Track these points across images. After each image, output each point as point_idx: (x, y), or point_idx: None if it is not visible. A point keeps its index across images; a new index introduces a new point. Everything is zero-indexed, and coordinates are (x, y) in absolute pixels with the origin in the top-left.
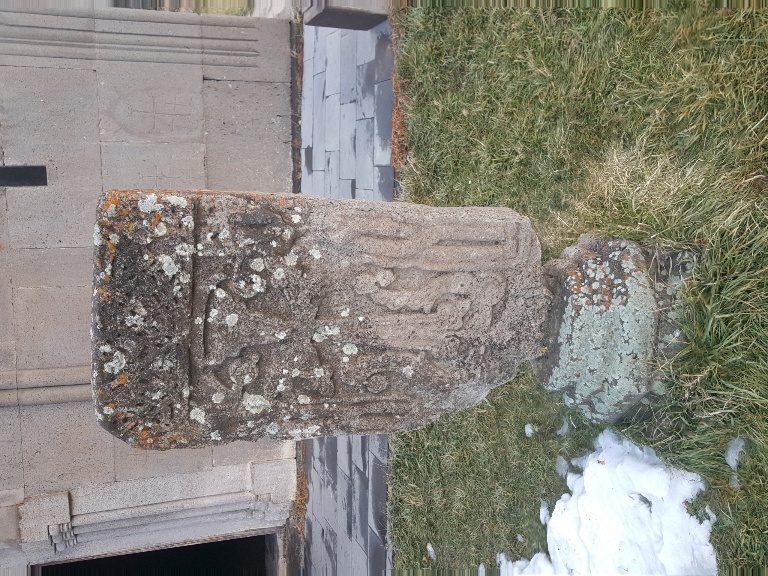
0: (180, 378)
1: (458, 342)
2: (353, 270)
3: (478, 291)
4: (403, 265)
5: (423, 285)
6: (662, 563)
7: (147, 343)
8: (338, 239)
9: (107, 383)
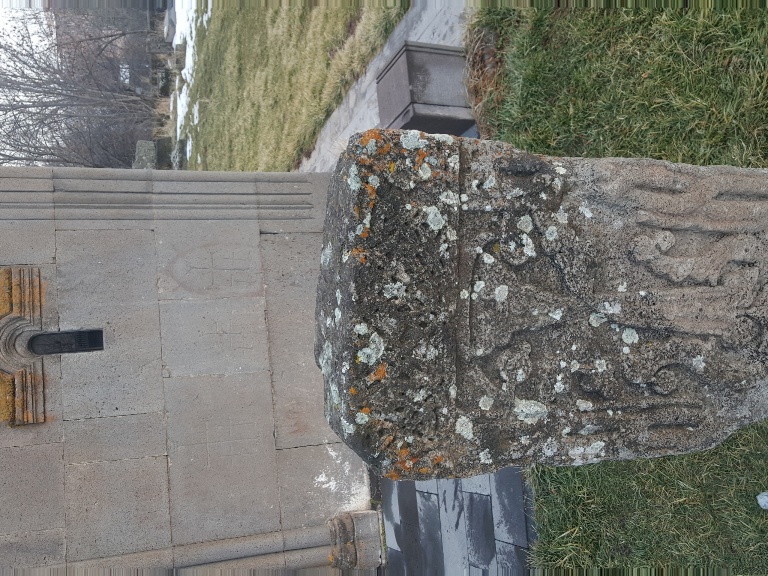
0: (446, 371)
1: (750, 323)
2: (627, 233)
3: (765, 257)
4: (683, 224)
5: (704, 251)
6: None
7: (409, 321)
8: (612, 191)
9: (361, 378)
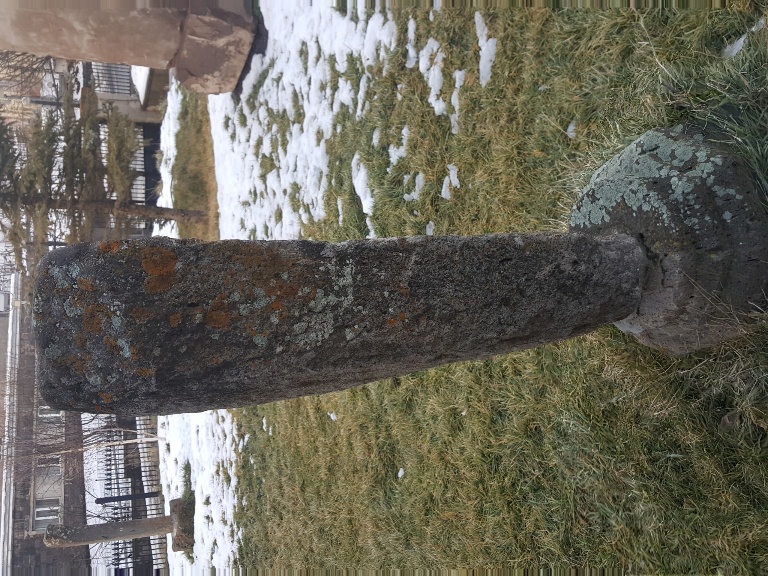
0: None
1: None
2: None
3: None
4: None
5: None
6: None
7: None
8: None
9: None
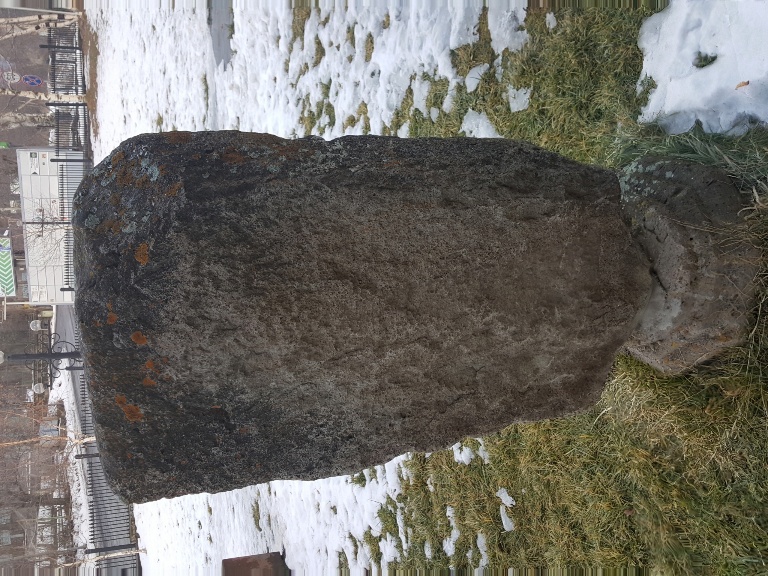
0: None
1: None
2: None
3: None
4: None
5: None
6: (687, 4)
7: None
8: None
9: None
